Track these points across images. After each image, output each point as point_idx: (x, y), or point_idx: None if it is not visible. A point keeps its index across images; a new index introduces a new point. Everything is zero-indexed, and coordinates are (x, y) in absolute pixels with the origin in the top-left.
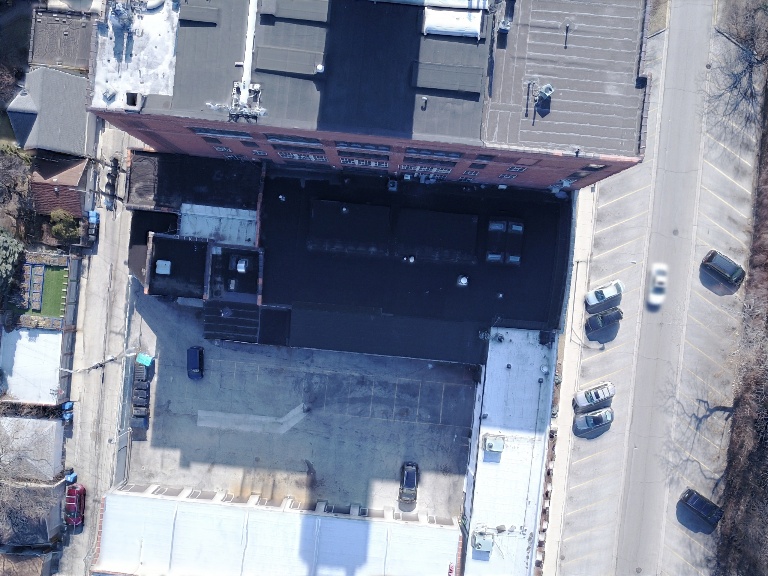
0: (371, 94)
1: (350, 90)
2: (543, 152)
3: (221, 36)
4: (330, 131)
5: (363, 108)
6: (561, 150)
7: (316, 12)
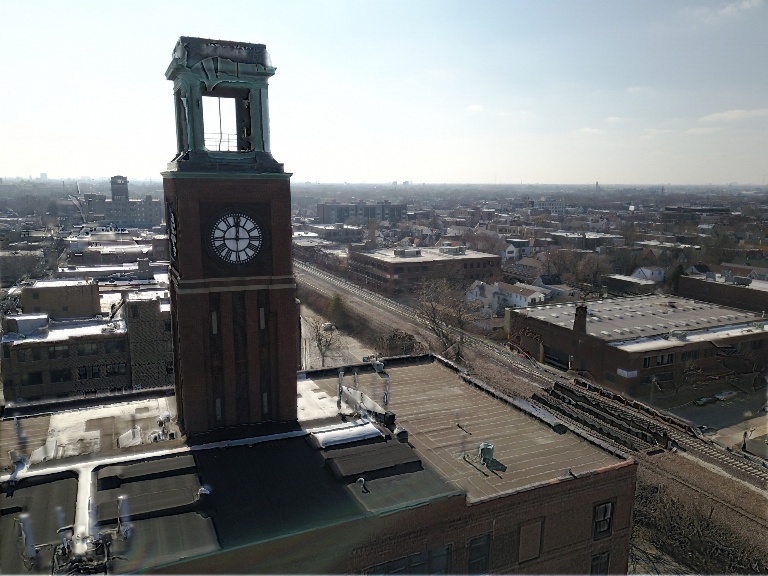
0: (287, 500)
1: (255, 505)
2: (538, 486)
3: (30, 517)
4: (245, 544)
5: (284, 513)
6: (553, 479)
7: (179, 463)
